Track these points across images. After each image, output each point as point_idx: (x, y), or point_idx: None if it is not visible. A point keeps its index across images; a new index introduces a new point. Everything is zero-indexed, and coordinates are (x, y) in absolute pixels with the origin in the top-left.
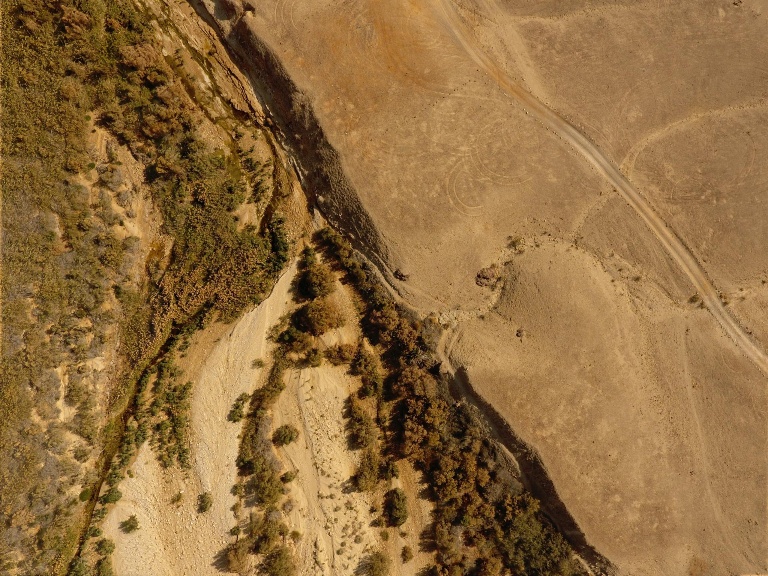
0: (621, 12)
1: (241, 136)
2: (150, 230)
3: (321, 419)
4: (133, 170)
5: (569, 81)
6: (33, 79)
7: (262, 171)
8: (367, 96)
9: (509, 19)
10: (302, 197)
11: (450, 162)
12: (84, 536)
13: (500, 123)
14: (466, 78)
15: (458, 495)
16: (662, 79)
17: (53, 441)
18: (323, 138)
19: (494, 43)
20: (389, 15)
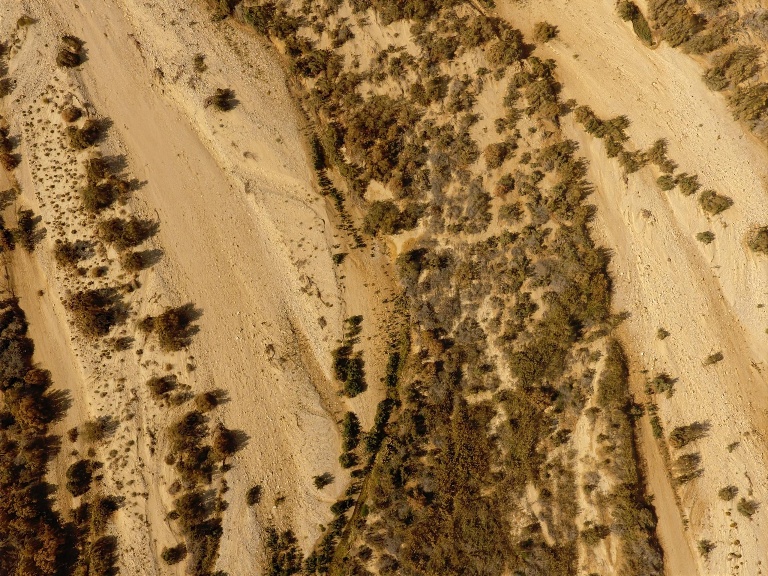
0: None
1: None
2: None
3: (139, 569)
4: None
5: None
6: None
7: None
8: None
9: None
10: None
11: None
12: (367, 472)
13: None
14: None
15: (16, 492)
16: None
17: (386, 575)
18: None
19: None
20: None
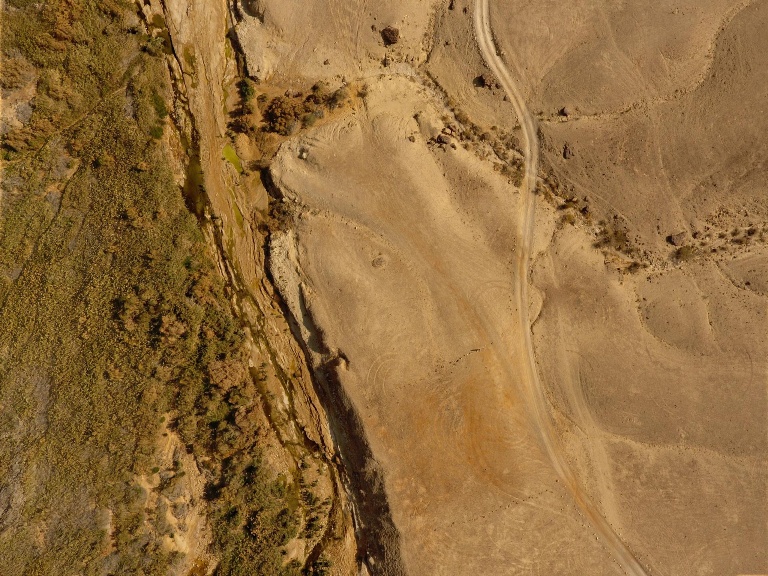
0: (715, 459)
1: (307, 467)
2: (198, 546)
3: None
4: (195, 482)
5: (647, 518)
6: (119, 377)
7: (319, 508)
8: (441, 483)
9: (600, 433)
10: (353, 545)
11: (509, 572)
12: None
13: (567, 542)
14: (543, 487)
15: None
16: (742, 542)
17: None
18: (388, 513)
19: (579, 454)
20: (481, 404)
